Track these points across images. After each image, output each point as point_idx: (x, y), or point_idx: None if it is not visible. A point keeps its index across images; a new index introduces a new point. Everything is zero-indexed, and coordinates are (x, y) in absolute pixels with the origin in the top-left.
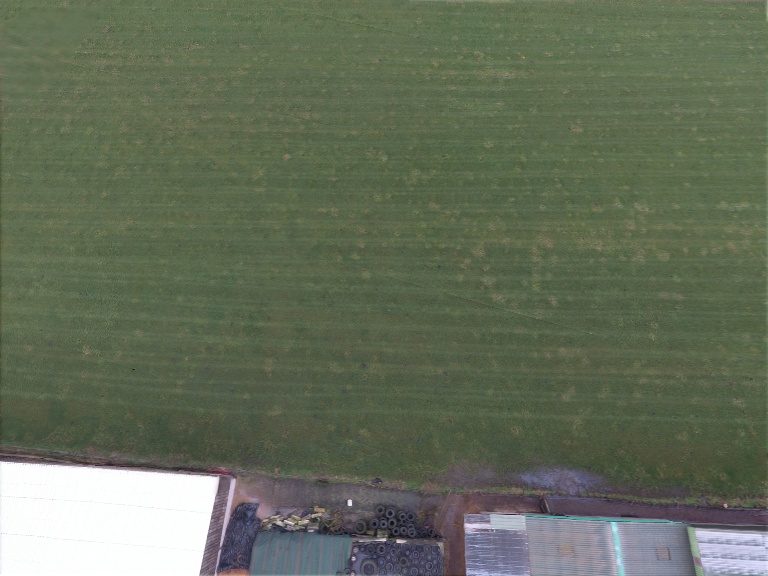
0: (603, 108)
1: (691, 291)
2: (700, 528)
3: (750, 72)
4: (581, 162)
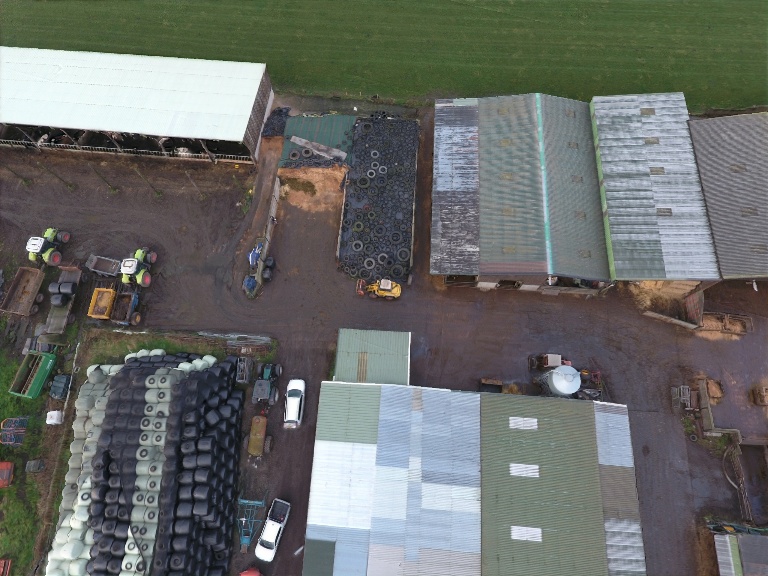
0: None
1: None
2: (596, 96)
3: None
4: None
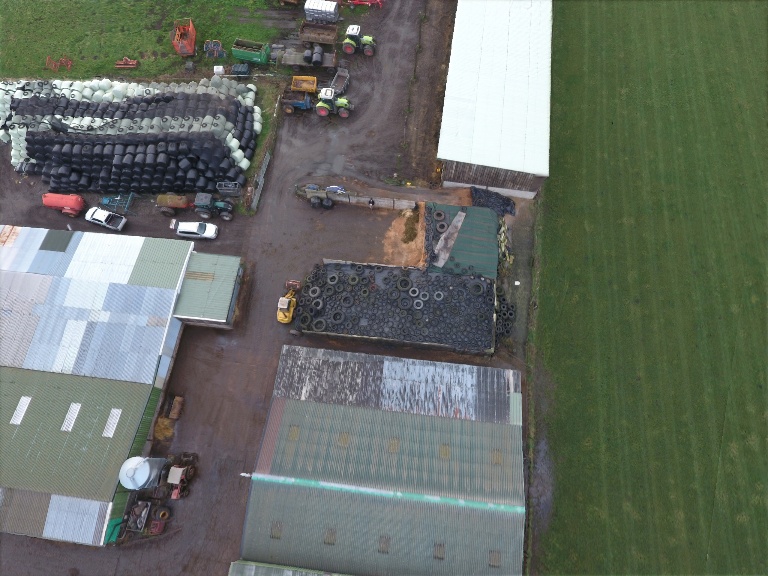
0: None
1: None
2: None
3: None
4: None
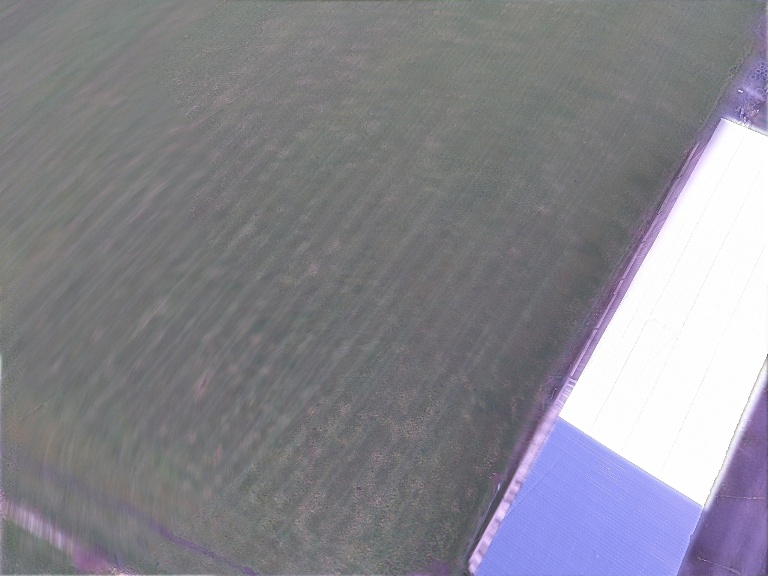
0: None
1: None
2: None
3: None
4: None
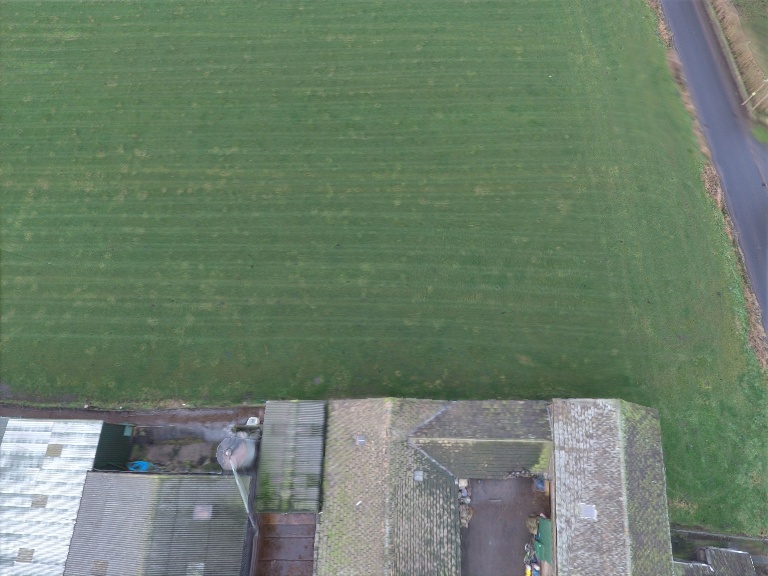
0: (143, 65)
1: (153, 226)
2: (12, 419)
3: (291, 31)
4: (102, 113)
